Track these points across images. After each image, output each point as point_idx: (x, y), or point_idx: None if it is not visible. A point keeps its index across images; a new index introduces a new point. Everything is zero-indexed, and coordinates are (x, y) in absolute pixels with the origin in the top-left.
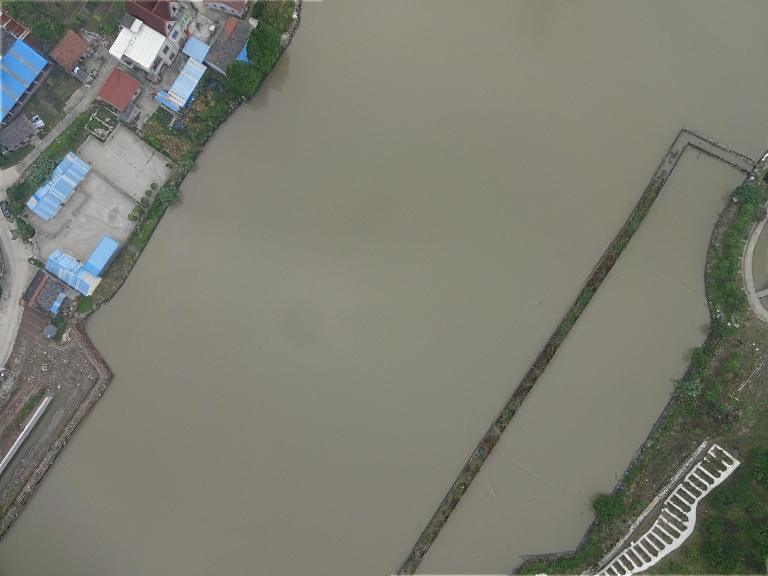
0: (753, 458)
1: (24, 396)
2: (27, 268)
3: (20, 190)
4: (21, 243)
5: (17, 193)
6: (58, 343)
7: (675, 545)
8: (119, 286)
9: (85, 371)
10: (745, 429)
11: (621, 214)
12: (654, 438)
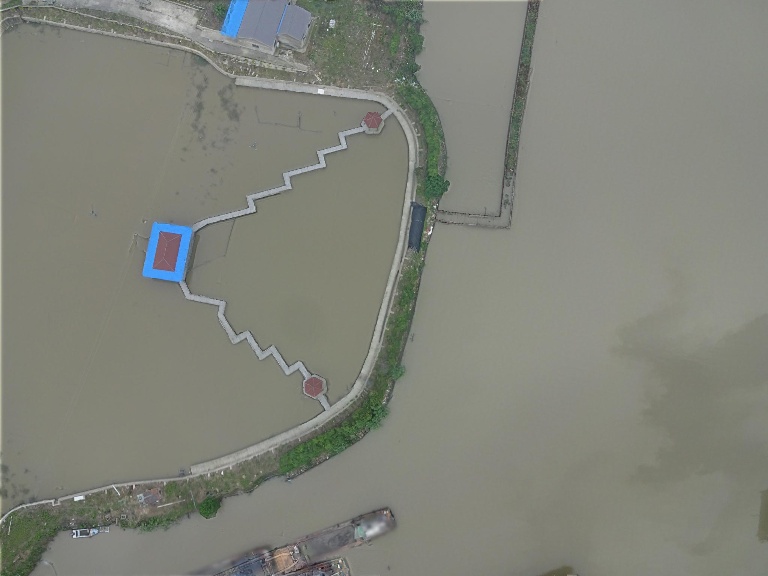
0: None
1: None
2: None
3: None
4: None
5: None
6: None
7: None
8: None
9: None
10: (359, 2)
11: None
12: None
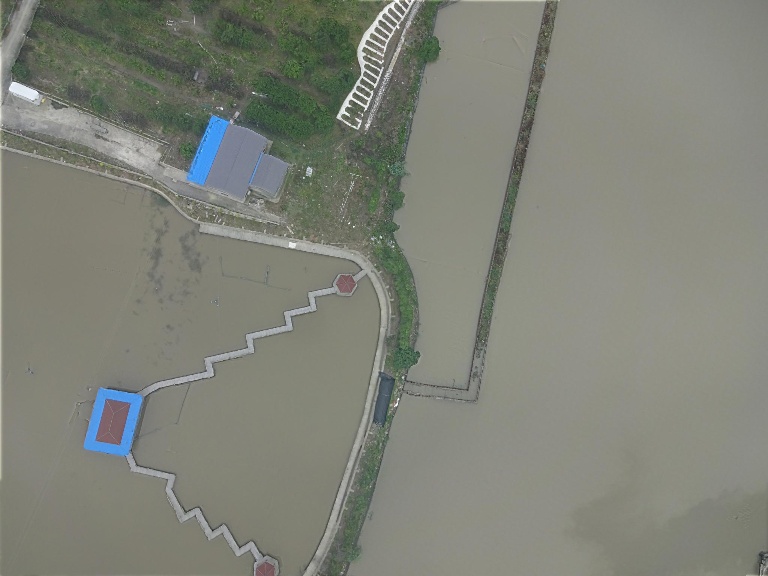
0: None
1: None
2: None
3: None
4: None
5: None
6: None
7: (368, 34)
8: None
9: None
10: (339, 150)
11: None
12: None
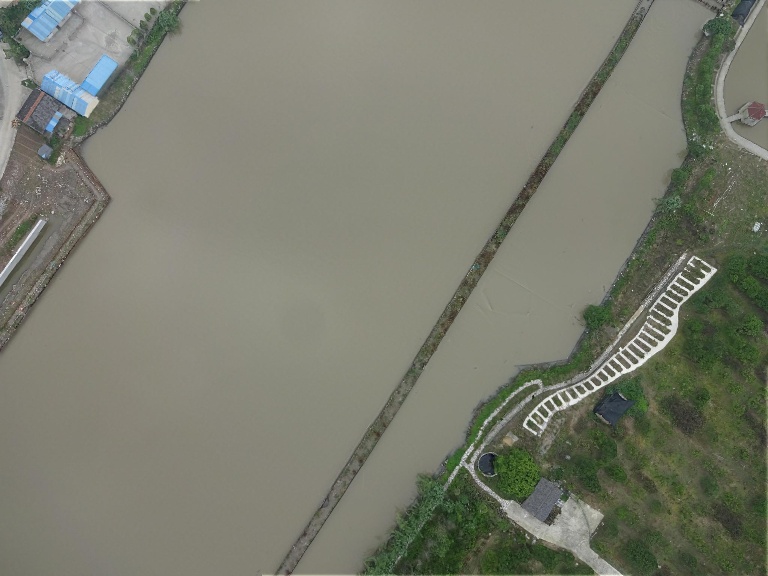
0: (729, 262)
1: (16, 220)
2: (20, 90)
3: (13, 13)
4: (14, 66)
5: (11, 13)
6: (53, 166)
7: (660, 347)
8: (117, 111)
9: (81, 195)
10: (720, 240)
11: (604, 47)
12: (639, 251)
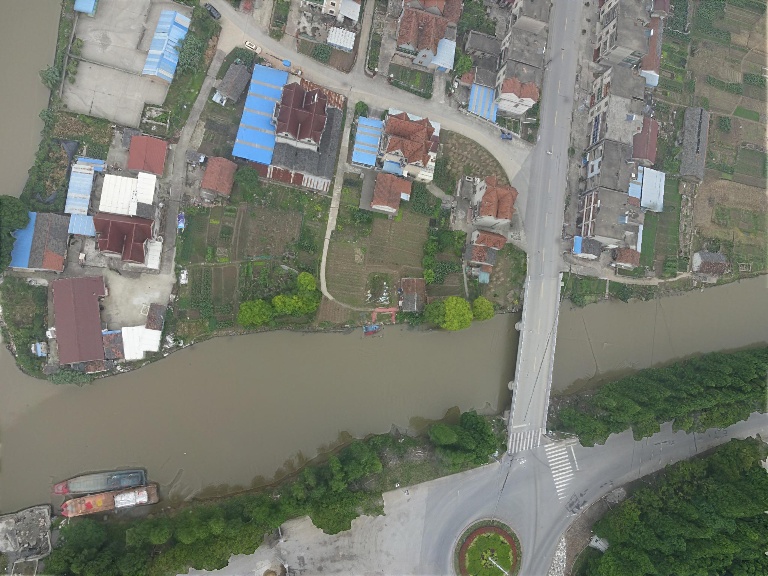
0: None
1: None
2: None
3: None
4: None
5: (203, 25)
6: None
7: None
8: None
9: None
10: None
11: None
12: None
